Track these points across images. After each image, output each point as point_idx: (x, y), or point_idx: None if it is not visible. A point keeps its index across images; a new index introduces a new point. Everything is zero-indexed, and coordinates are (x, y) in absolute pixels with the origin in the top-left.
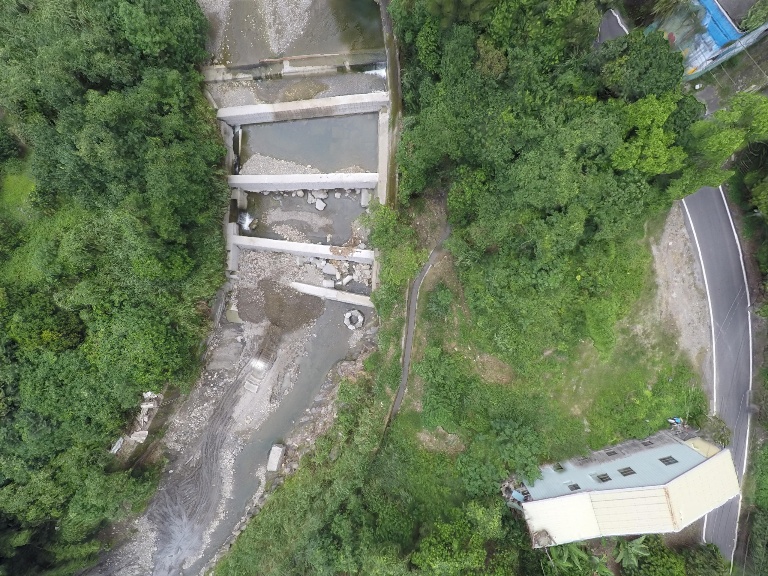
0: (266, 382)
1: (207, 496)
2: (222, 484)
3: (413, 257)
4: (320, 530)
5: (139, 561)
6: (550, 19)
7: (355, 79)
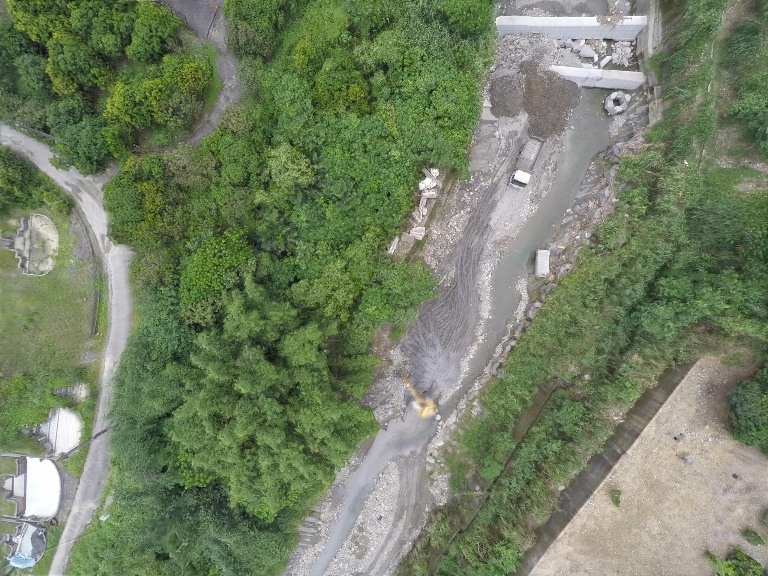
0: None
1: (464, 318)
2: (480, 303)
3: None
4: (640, 301)
5: (392, 399)
6: None
7: None
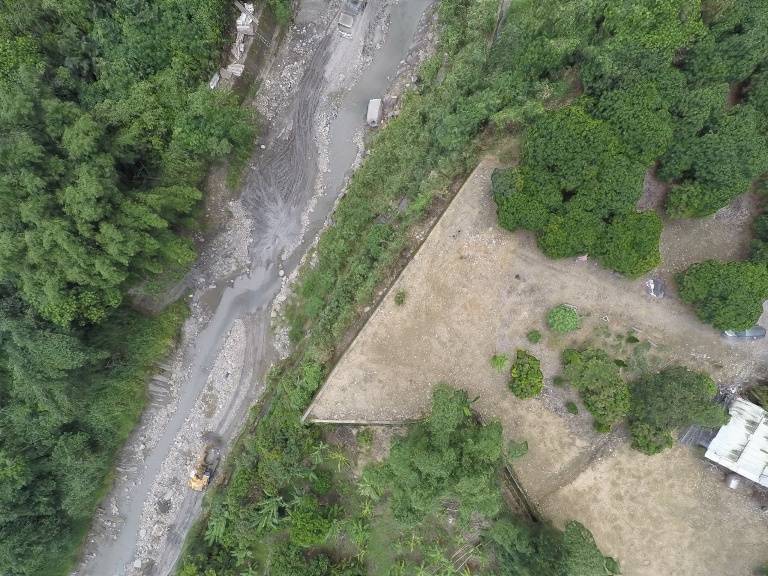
0: (357, 33)
1: (303, 171)
2: (318, 156)
3: None
4: None
5: (235, 253)
6: None
7: None
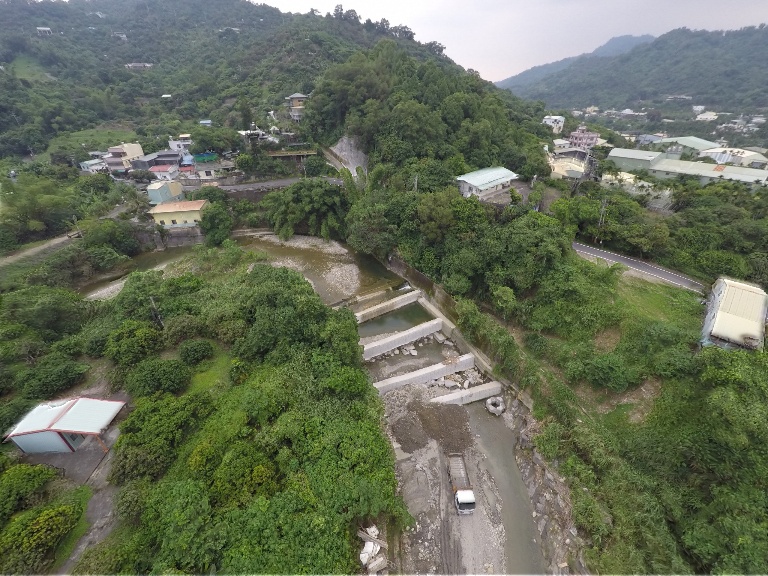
0: None
1: None
2: None
3: (507, 287)
4: None
5: None
6: (480, 214)
7: (396, 293)
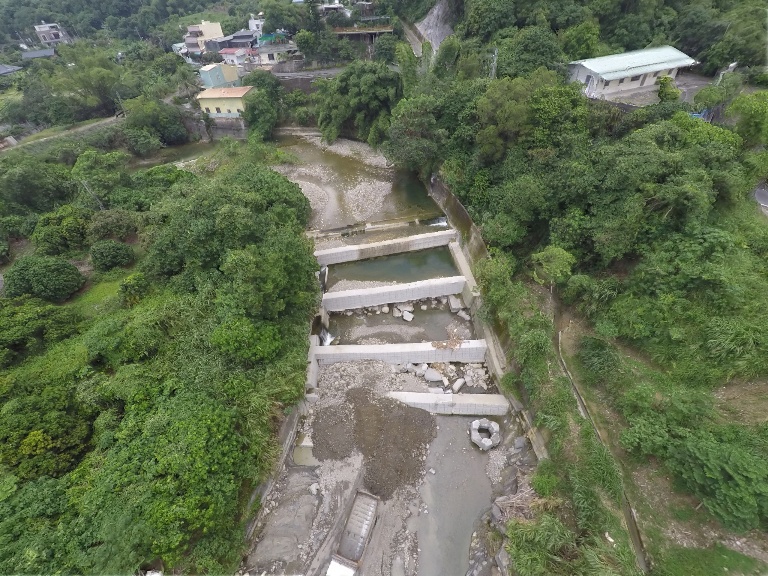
0: None
1: None
2: None
3: (561, 250)
4: None
5: None
6: (578, 116)
7: (423, 229)
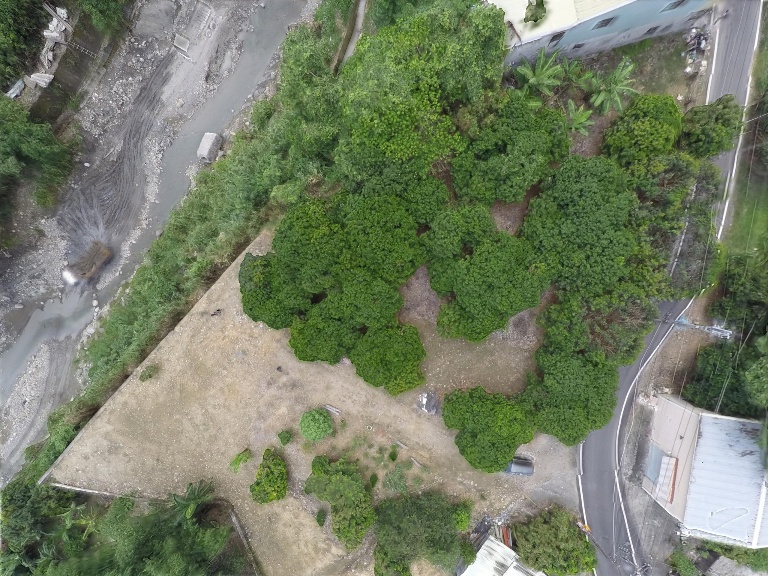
0: (202, 56)
1: (128, 198)
2: (146, 184)
3: None
4: None
5: (45, 275)
6: None
7: None
